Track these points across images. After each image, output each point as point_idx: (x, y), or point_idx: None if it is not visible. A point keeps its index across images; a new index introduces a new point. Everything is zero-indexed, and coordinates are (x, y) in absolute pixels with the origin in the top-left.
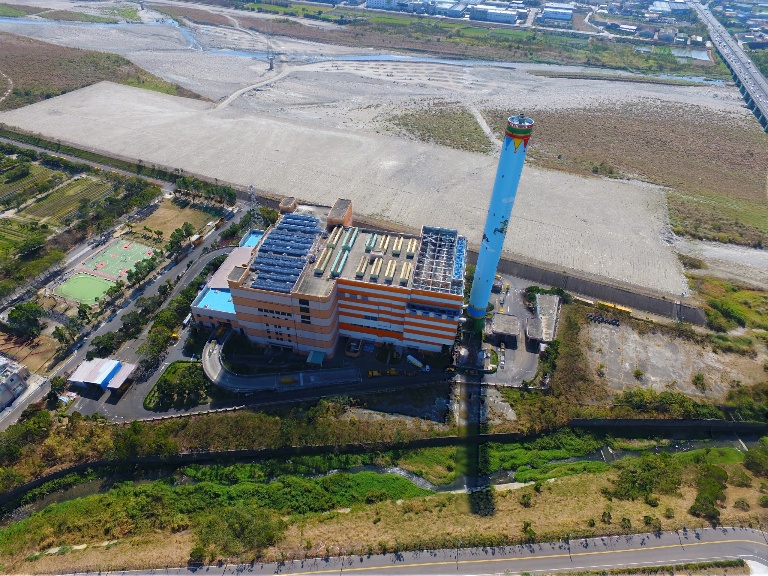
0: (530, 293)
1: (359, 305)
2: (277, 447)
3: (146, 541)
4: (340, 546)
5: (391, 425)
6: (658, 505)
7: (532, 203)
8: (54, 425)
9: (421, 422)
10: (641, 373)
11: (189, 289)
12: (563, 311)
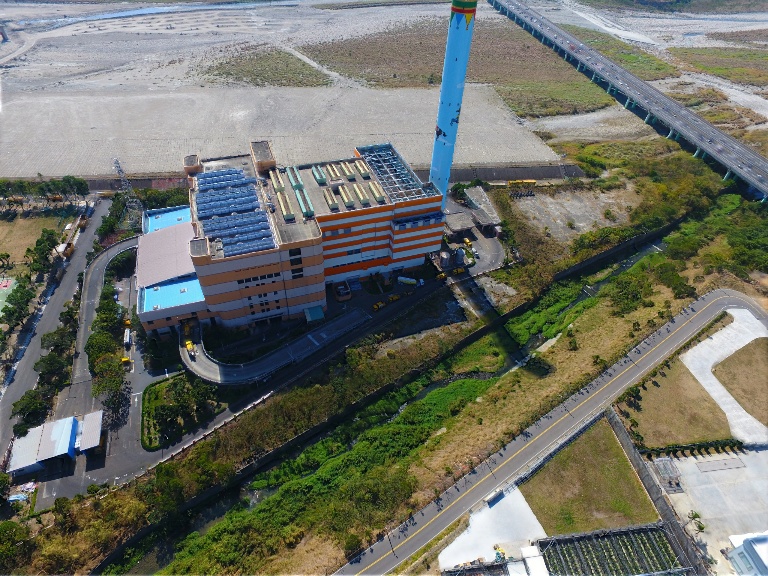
0: (459, 190)
1: (341, 241)
2: (343, 409)
3: (272, 573)
4: (475, 455)
5: (426, 342)
6: (654, 304)
7: (401, 119)
8: (30, 532)
9: (449, 328)
10: (572, 224)
11: (106, 303)
12: (489, 198)
